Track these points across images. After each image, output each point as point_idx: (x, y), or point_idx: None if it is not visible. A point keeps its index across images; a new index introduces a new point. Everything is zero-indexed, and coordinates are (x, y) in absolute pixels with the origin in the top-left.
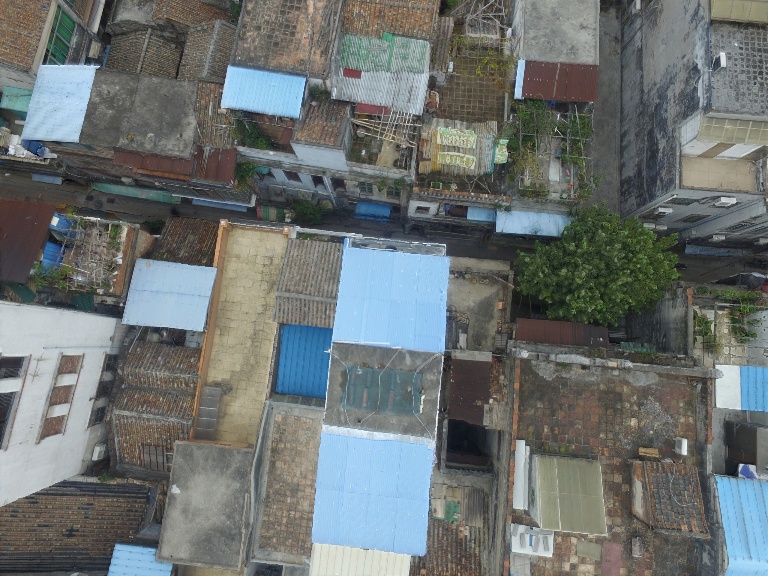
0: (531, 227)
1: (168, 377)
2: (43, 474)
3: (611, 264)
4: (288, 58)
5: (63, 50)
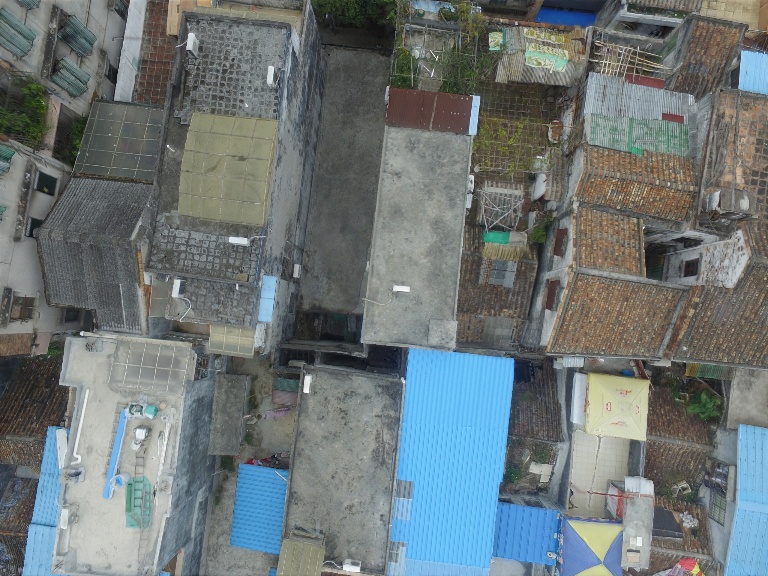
0: None
1: None
2: None
3: None
4: (763, 113)
5: None
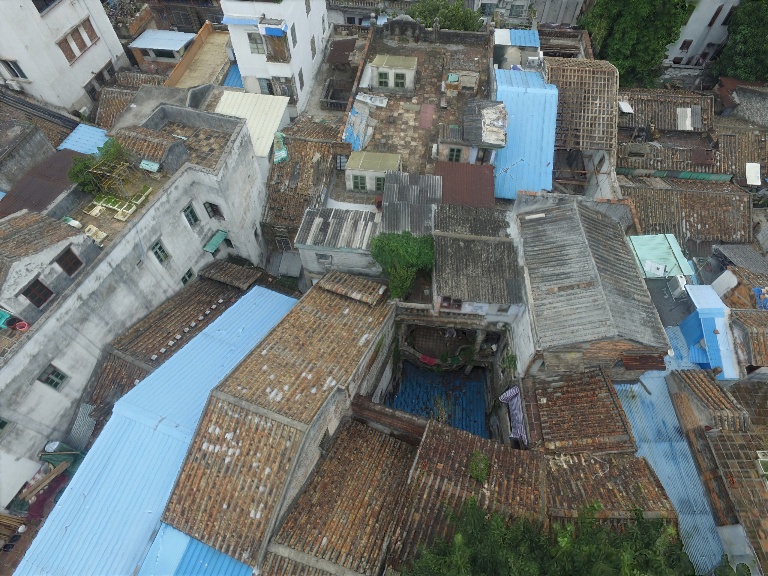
0: None
1: (147, 78)
2: (50, 69)
3: None
4: None
5: None
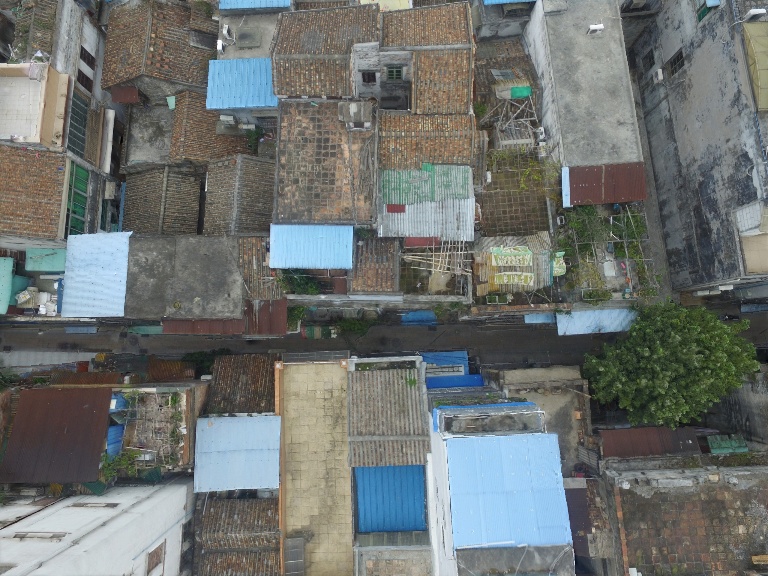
0: (594, 326)
1: (248, 537)
2: None
3: (689, 364)
4: (332, 208)
5: (81, 202)
